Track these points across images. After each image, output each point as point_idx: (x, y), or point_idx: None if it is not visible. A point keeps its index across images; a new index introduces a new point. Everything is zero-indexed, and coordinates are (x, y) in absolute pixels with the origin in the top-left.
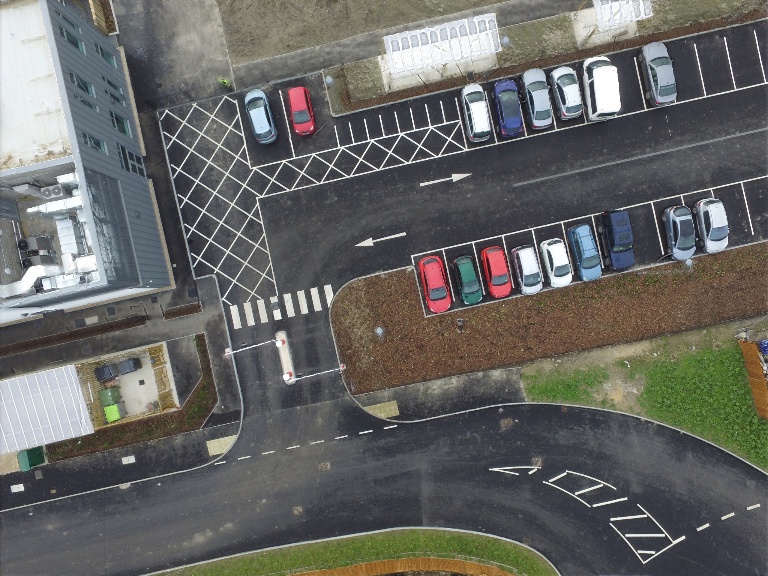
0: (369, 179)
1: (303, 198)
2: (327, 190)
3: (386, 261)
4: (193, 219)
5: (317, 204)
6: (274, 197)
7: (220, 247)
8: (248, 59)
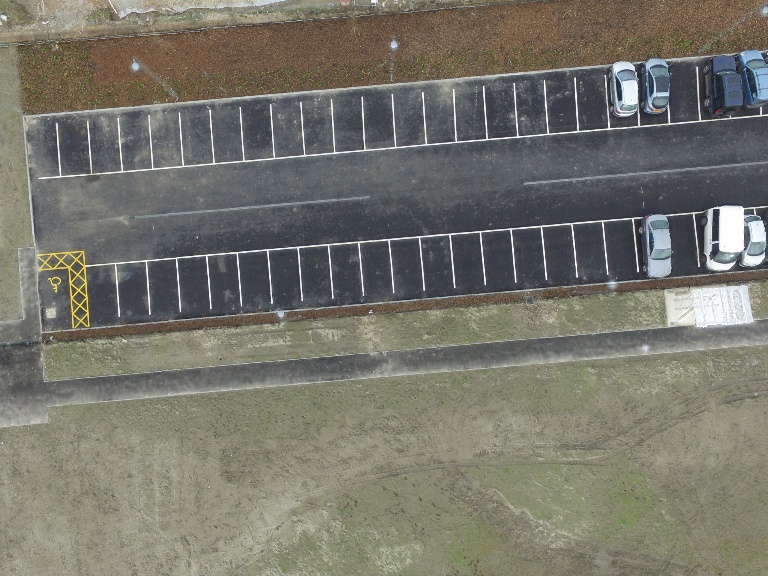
0: None
1: None
2: None
3: None
4: None
5: None
6: None
7: None
8: None
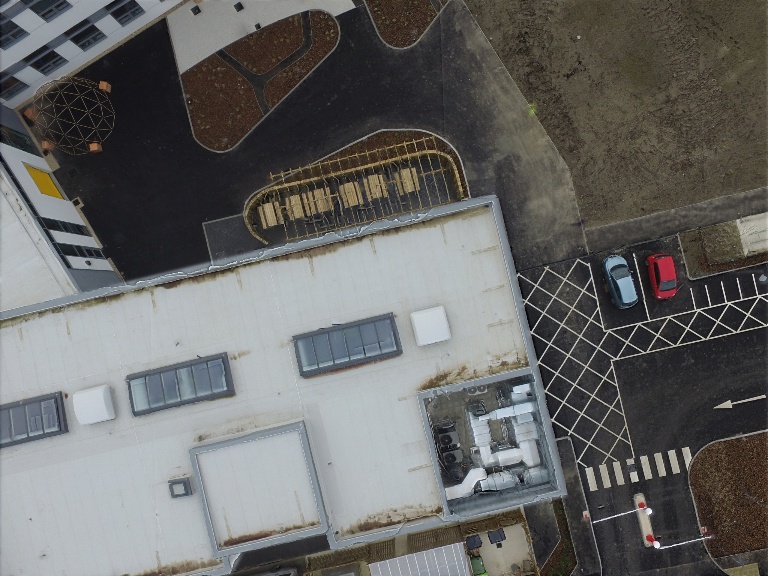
0: (727, 341)
1: (659, 360)
2: (683, 352)
3: (746, 424)
4: (546, 381)
5: (673, 366)
6: (629, 359)
7: (574, 409)
8: (601, 222)
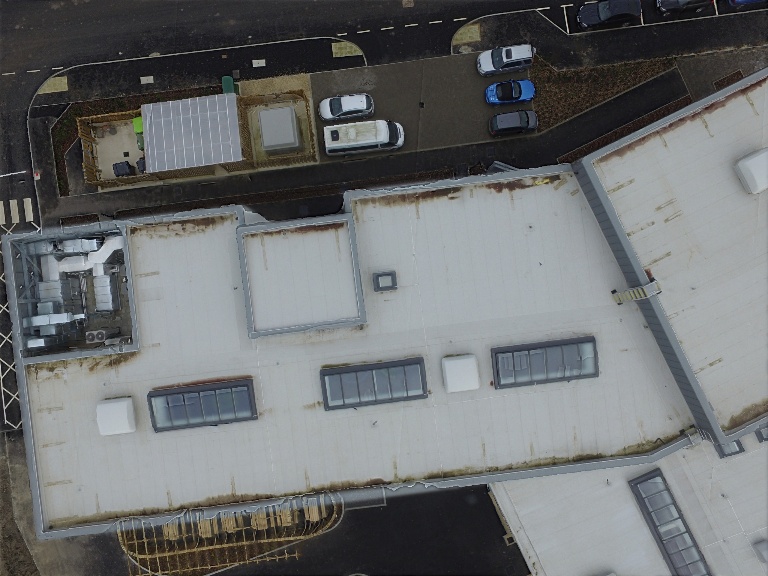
0: None
1: None
2: None
3: None
4: None
5: None
6: None
7: None
8: None
